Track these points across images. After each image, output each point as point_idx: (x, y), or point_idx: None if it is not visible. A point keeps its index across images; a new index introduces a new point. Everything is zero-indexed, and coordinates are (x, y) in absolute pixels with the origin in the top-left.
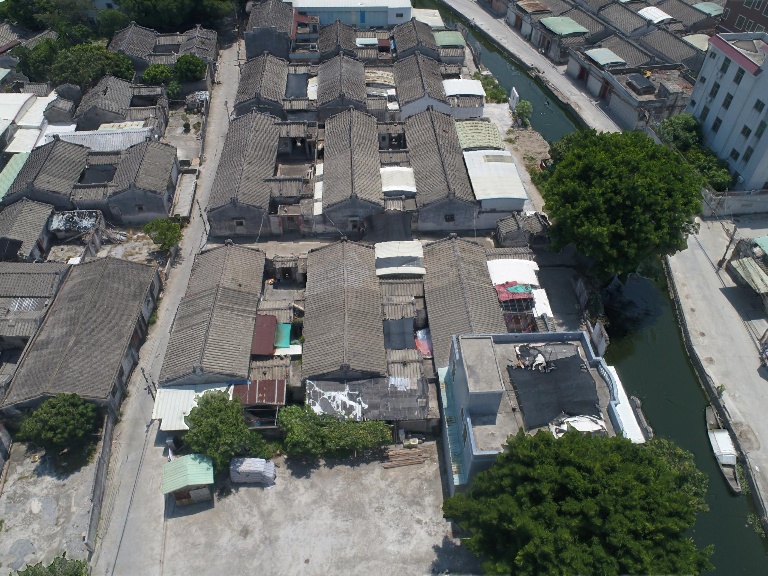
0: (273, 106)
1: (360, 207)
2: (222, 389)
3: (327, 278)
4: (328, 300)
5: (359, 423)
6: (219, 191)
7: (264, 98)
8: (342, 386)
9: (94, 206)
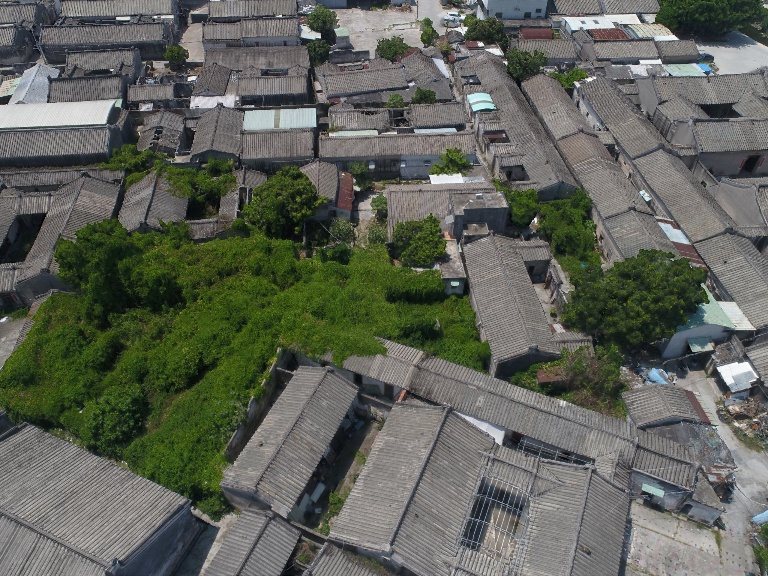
0: (24, 32)
1: (175, 4)
2: (302, 26)
3: (235, 8)
4: (251, 7)
5: (318, 7)
6: (143, 35)
7: (19, 27)
8: (301, 7)
9: (134, 78)
